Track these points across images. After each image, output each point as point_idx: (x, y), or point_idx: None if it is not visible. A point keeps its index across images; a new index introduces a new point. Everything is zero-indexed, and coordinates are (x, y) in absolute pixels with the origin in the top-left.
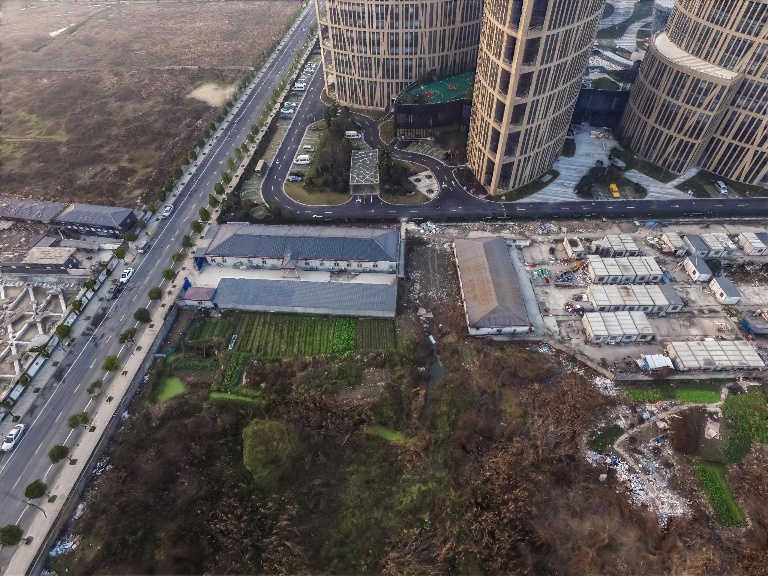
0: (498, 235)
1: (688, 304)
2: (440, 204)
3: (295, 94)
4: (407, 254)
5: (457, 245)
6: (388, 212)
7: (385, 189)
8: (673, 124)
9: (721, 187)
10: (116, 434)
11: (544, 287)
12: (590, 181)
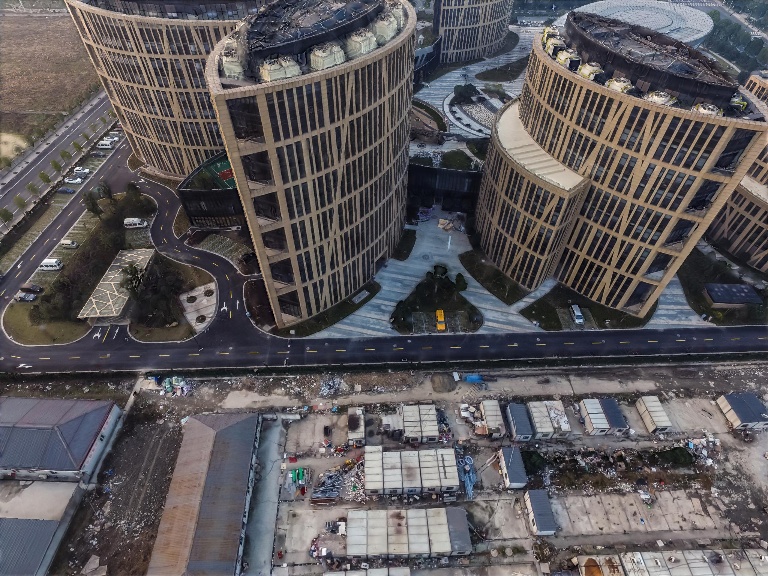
0: (266, 398)
1: (487, 536)
2: (205, 342)
3: (96, 154)
4: (118, 441)
5: (186, 430)
6: (128, 357)
7: (139, 317)
8: (515, 232)
9: (575, 315)
10: None
11: (294, 503)
12: (414, 302)
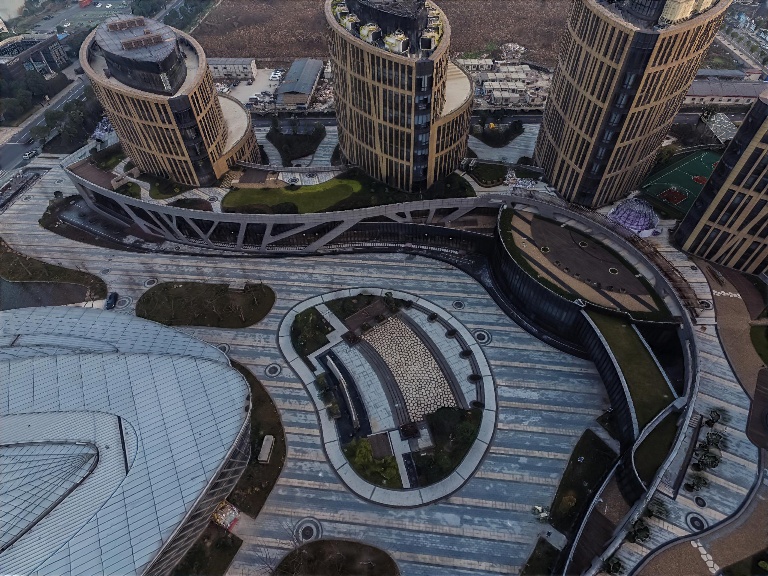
0: None
1: None
2: None
3: None
4: None
5: None
6: None
7: None
8: None
9: None
10: (723, 49)
11: None
12: (510, 134)
